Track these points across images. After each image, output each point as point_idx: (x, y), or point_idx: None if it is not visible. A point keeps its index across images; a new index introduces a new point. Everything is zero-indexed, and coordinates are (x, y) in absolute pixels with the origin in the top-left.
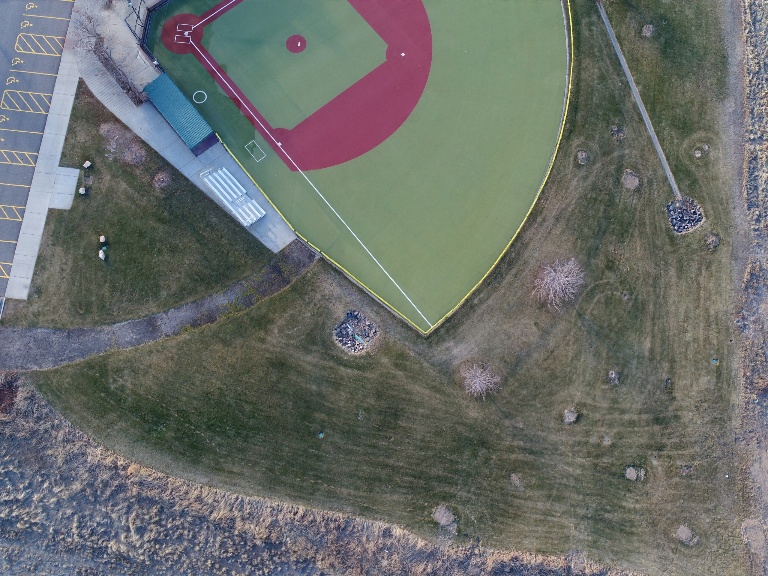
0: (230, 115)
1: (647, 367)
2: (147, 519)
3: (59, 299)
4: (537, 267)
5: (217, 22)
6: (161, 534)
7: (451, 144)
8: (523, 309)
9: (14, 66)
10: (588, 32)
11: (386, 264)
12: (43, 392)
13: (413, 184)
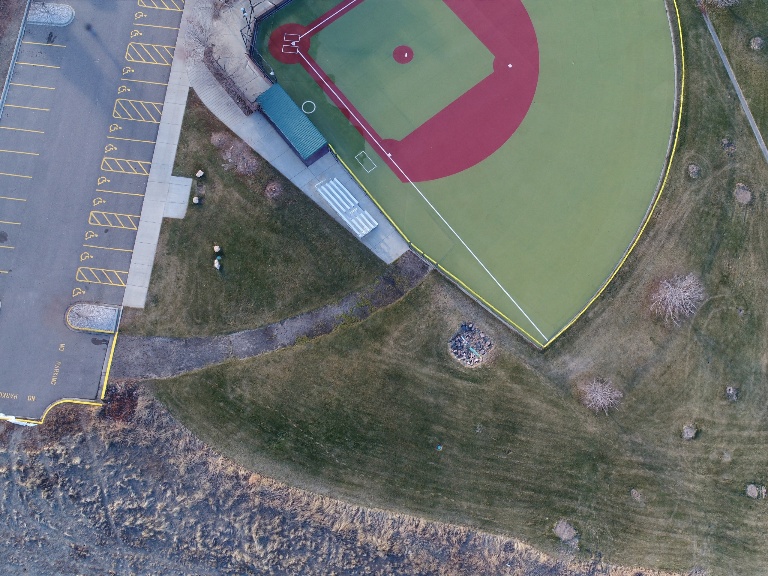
0: (339, 125)
1: (765, 383)
2: (270, 529)
3: (176, 308)
4: (651, 281)
5: (324, 32)
6: (284, 545)
7: (561, 156)
8: (638, 323)
9: (125, 75)
10: (695, 44)
11: (499, 276)
12: (163, 401)
13: (524, 196)
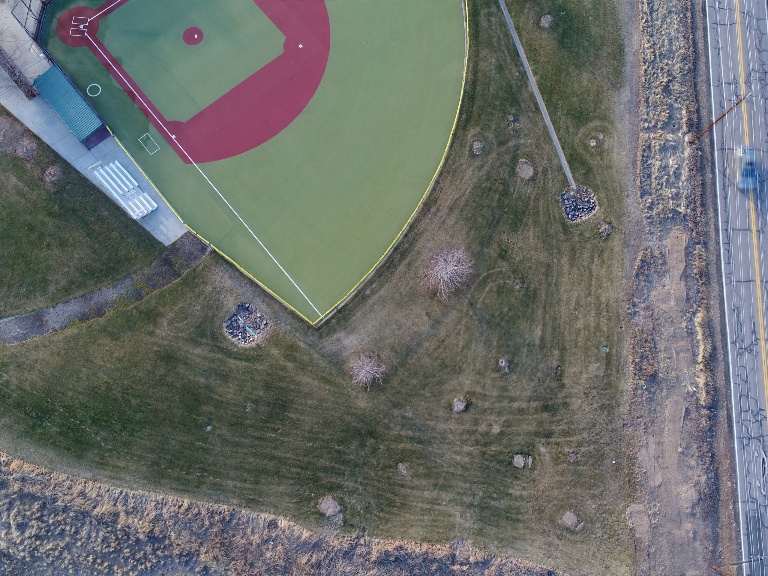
0: (124, 108)
1: (537, 355)
2: (29, 515)
3: None
4: (430, 257)
5: (113, 15)
6: (42, 530)
7: (347, 135)
8: (415, 299)
9: None
10: (487, 23)
11: (278, 256)
12: None
13: (308, 175)
